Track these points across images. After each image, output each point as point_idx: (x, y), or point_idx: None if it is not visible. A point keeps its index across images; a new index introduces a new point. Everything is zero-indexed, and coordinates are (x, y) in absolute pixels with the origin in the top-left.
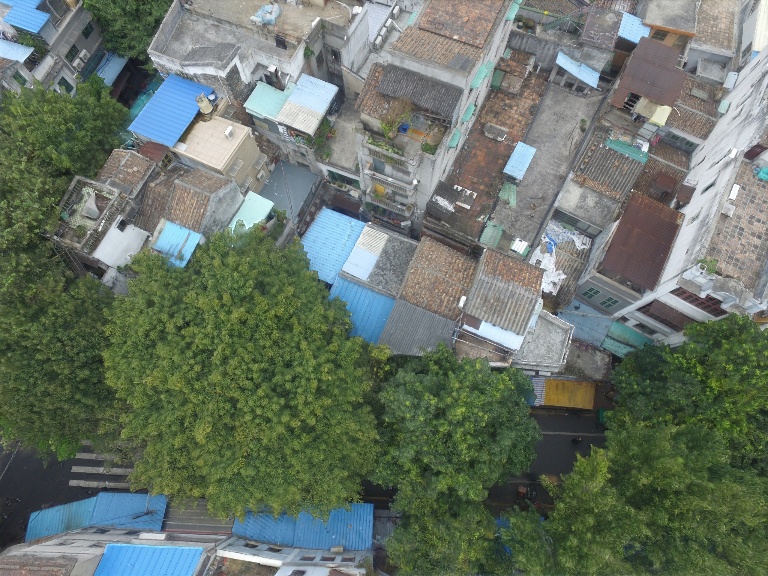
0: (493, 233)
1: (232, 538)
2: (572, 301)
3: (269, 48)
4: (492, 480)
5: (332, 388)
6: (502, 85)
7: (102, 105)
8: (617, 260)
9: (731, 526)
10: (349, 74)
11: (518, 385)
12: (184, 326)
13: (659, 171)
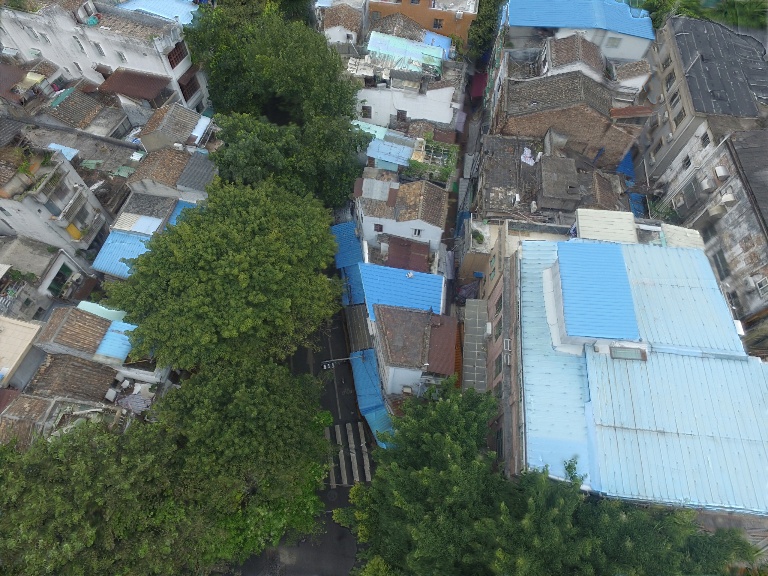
0: (125, 171)
1: None
2: None
3: None
4: None
5: None
6: None
7: None
8: (150, 93)
9: None
10: None
11: None
12: None
13: None
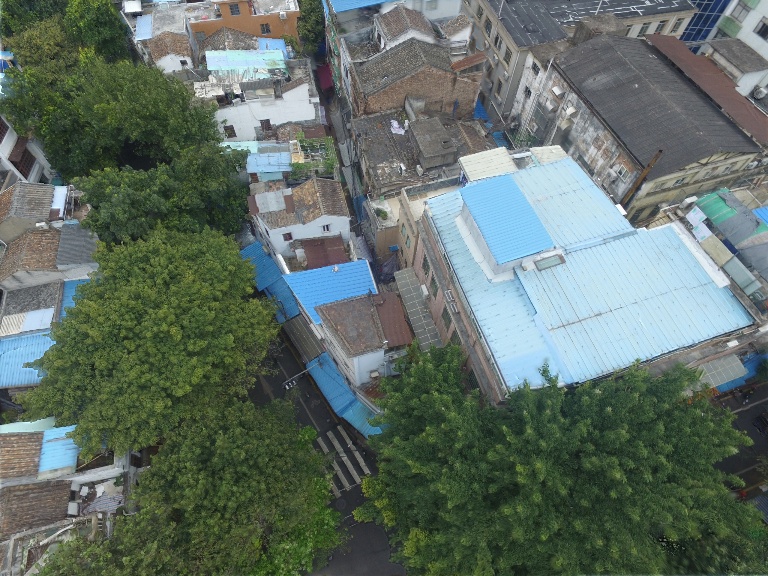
0: None
1: None
2: None
3: None
4: None
5: None
6: None
7: None
8: None
9: None
10: None
11: None
12: None
13: None
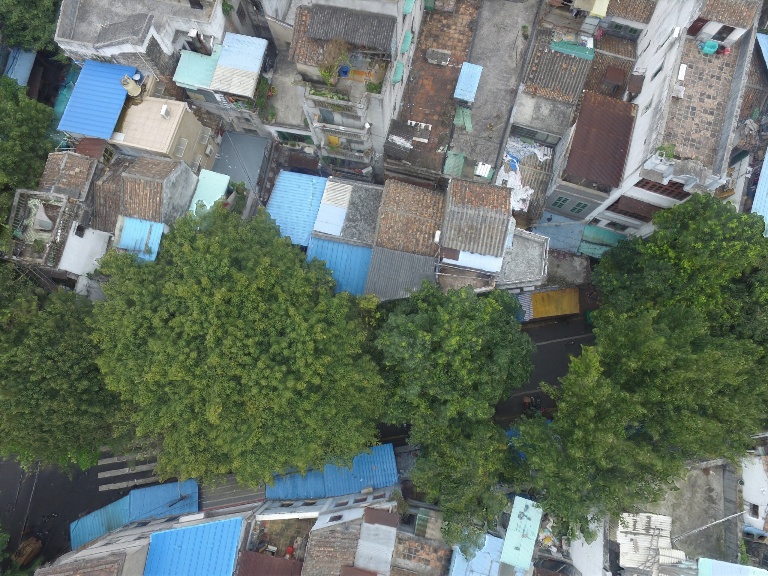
0: (455, 162)
1: (267, 502)
2: (543, 214)
3: (184, 11)
4: (497, 397)
5: (329, 346)
6: (436, 5)
7: (23, 109)
8: (579, 164)
9: (718, 389)
10: (275, 24)
11: (505, 305)
12: (170, 318)
13: (607, 65)
